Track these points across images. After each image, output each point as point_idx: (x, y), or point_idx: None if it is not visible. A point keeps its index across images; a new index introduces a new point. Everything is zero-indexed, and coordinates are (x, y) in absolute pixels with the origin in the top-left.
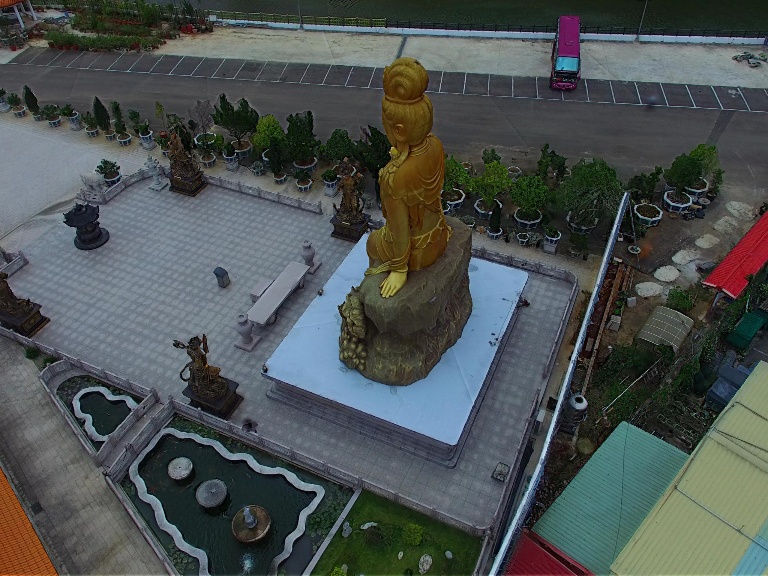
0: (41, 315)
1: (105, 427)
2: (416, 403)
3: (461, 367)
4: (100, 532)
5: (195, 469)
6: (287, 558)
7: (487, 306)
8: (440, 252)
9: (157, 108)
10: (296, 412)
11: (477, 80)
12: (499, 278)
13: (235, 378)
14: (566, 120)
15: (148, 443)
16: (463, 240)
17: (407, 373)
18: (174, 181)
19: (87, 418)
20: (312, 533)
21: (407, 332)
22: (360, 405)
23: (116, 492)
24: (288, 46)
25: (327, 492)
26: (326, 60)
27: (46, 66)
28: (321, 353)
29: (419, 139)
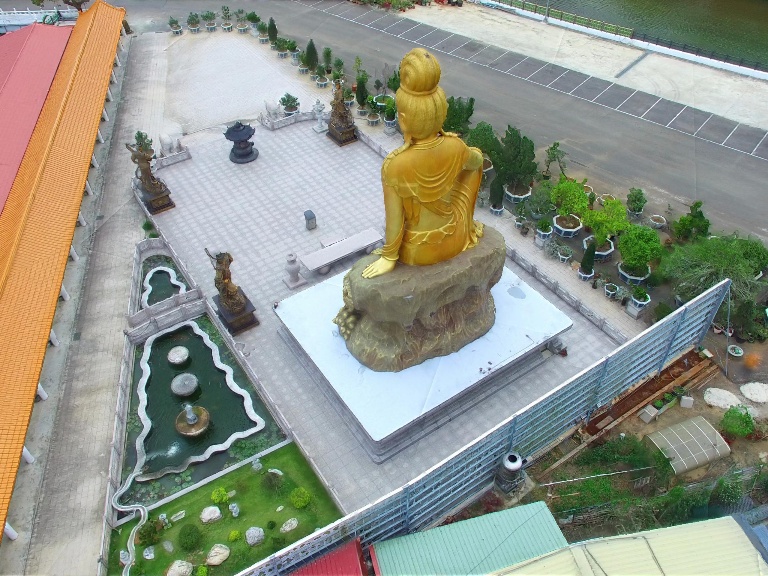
0: (170, 200)
1: (156, 301)
2: (372, 389)
3: (436, 378)
4: (100, 373)
5: (192, 362)
6: (201, 461)
7: (505, 335)
8: (443, 257)
9: (356, 62)
10: (289, 354)
11: (693, 116)
12: (539, 314)
13: (265, 305)
14: (767, 187)
15: (172, 325)
16: (479, 255)
17: (378, 359)
18: (331, 128)
19: (148, 288)
20: (232, 453)
21: (379, 318)
22: (326, 368)
23: (123, 349)
24: (520, 35)
25: (266, 428)
26: (547, 57)
27: (309, 6)
28: (329, 312)
29: (421, 133)
